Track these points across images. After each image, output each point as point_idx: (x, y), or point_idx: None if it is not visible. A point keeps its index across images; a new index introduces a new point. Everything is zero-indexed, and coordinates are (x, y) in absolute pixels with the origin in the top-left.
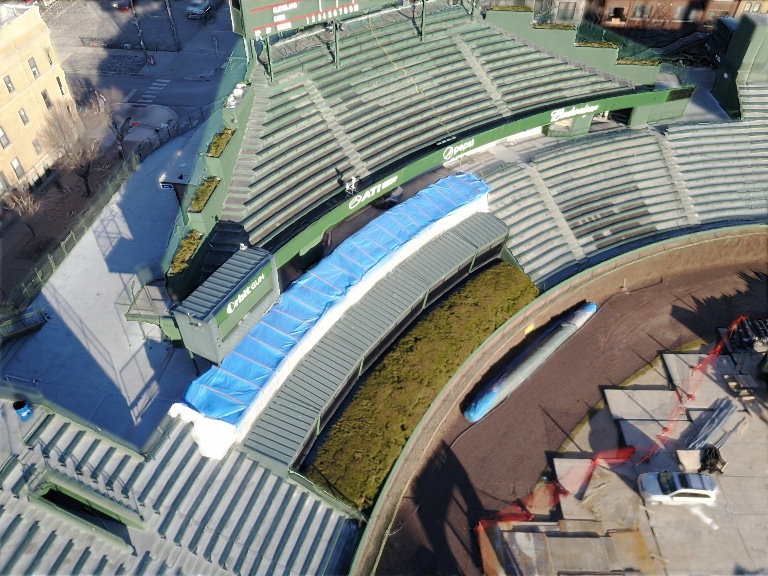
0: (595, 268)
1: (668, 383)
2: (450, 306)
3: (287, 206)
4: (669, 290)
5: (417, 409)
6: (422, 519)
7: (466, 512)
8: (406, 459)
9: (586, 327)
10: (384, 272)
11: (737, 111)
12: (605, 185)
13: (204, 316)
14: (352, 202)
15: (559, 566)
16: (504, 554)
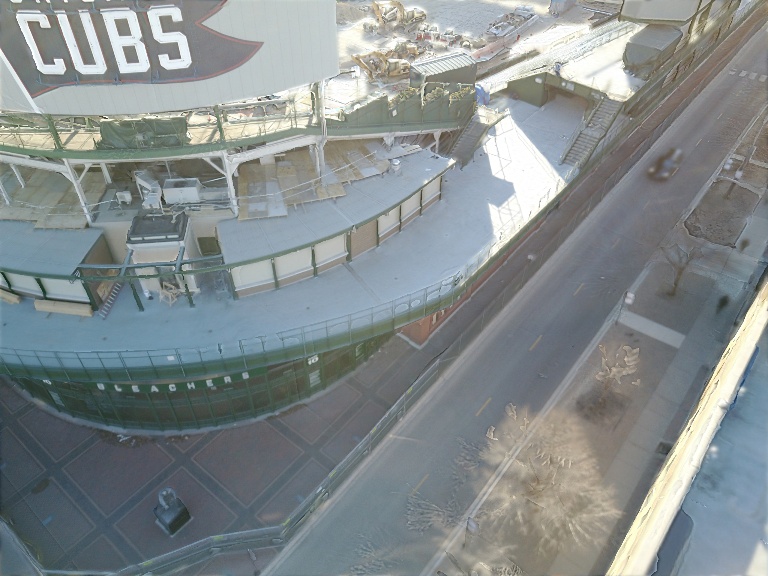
0: None
1: None
2: None
3: None
4: None
5: None
6: None
7: None
8: None
9: None
10: None
11: None
12: None
13: (463, 54)
14: None
15: (343, 105)
16: None
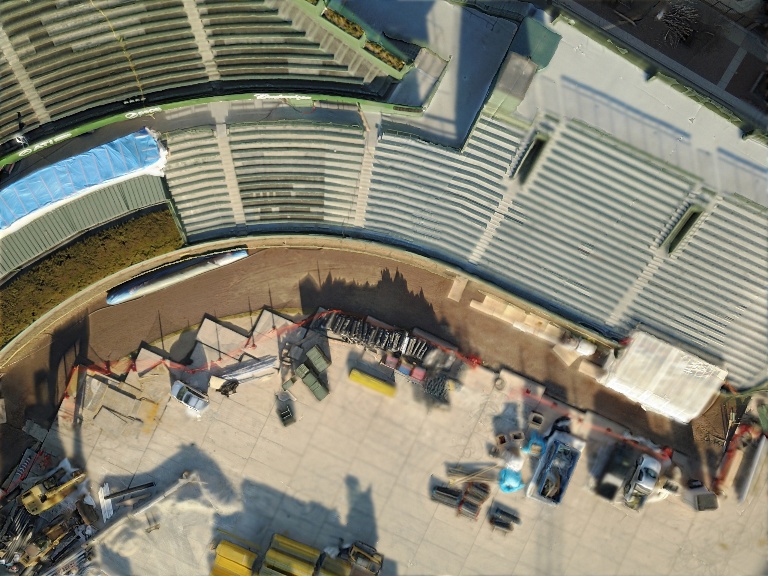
0: (241, 239)
1: (250, 331)
2: (105, 237)
3: None
4: (318, 259)
5: (47, 306)
6: (52, 349)
7: (77, 356)
8: (37, 327)
9: (232, 265)
10: (43, 213)
11: (463, 142)
12: (293, 169)
13: None
14: (21, 154)
15: (104, 403)
16: (81, 386)
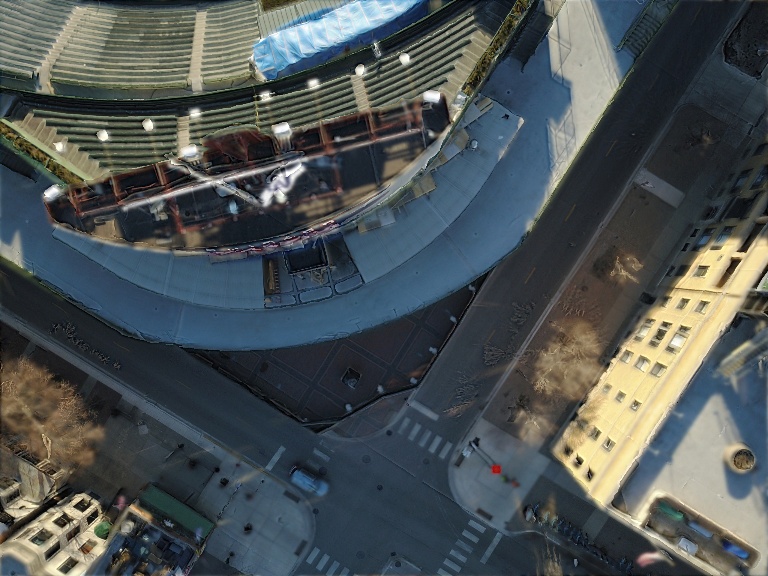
0: None
1: None
2: None
3: (436, 43)
4: None
5: None
6: None
7: None
8: None
9: None
10: None
11: None
12: None
13: None
14: None
15: None
16: None
